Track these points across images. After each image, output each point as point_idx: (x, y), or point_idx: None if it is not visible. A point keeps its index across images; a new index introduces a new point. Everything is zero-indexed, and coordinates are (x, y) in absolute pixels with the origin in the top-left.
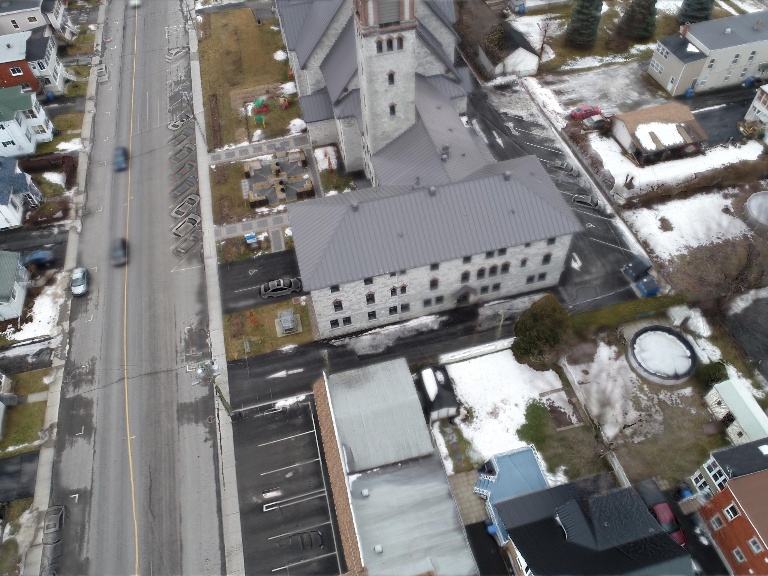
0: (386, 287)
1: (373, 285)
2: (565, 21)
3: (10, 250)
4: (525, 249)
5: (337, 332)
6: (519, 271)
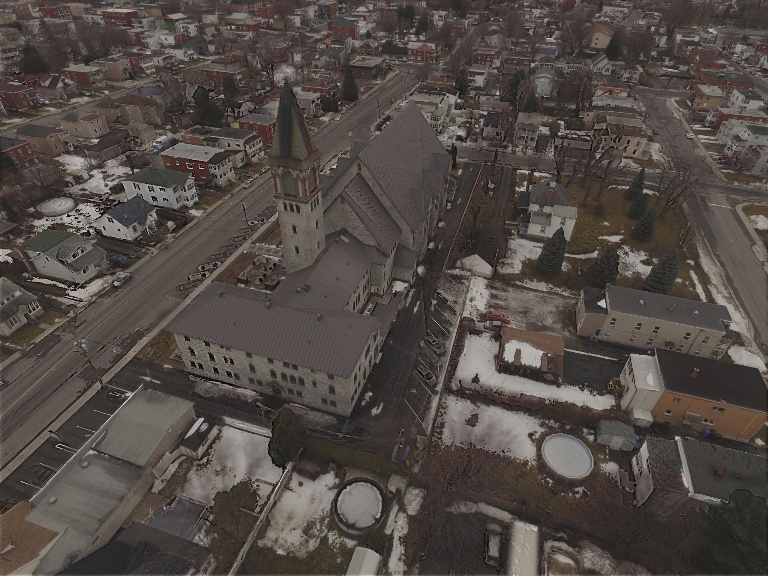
0: (220, 354)
1: (211, 348)
2: None
3: (116, 251)
4: (312, 373)
5: (196, 371)
6: (313, 389)
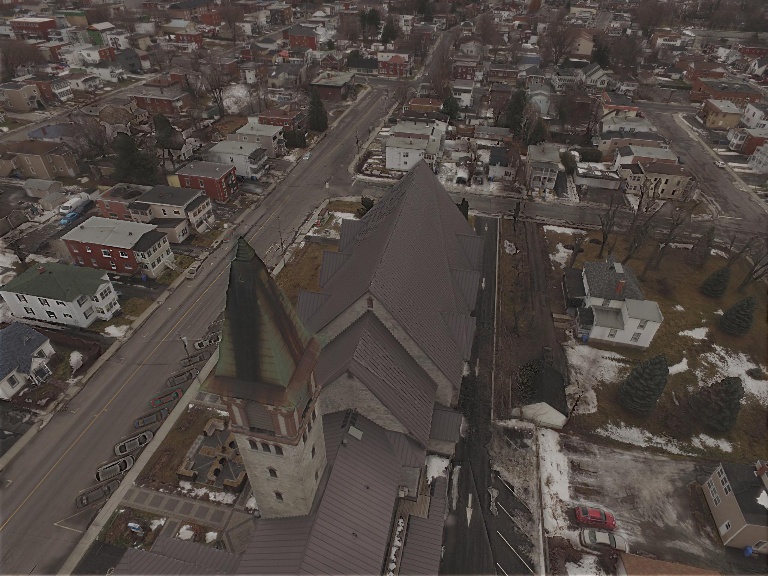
0: None
1: None
2: (629, 368)
3: None
4: None
5: None
6: None
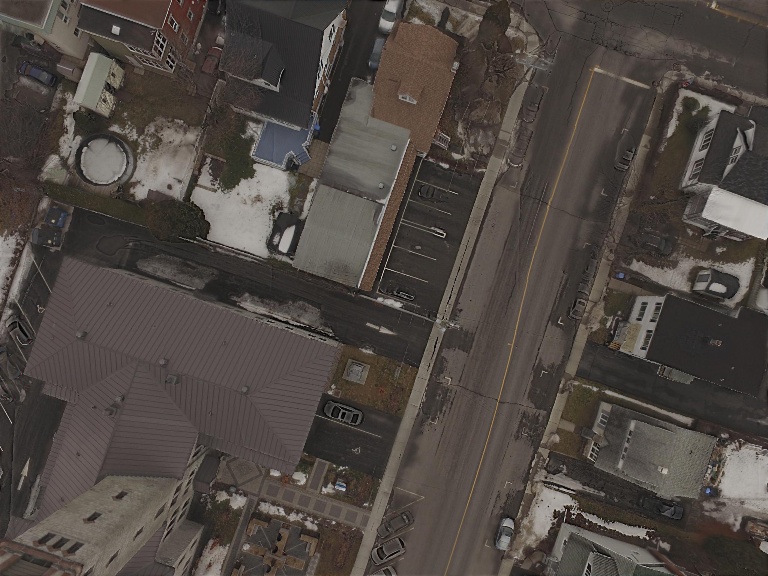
0: None
1: None
2: None
3: None
4: None
5: None
6: None
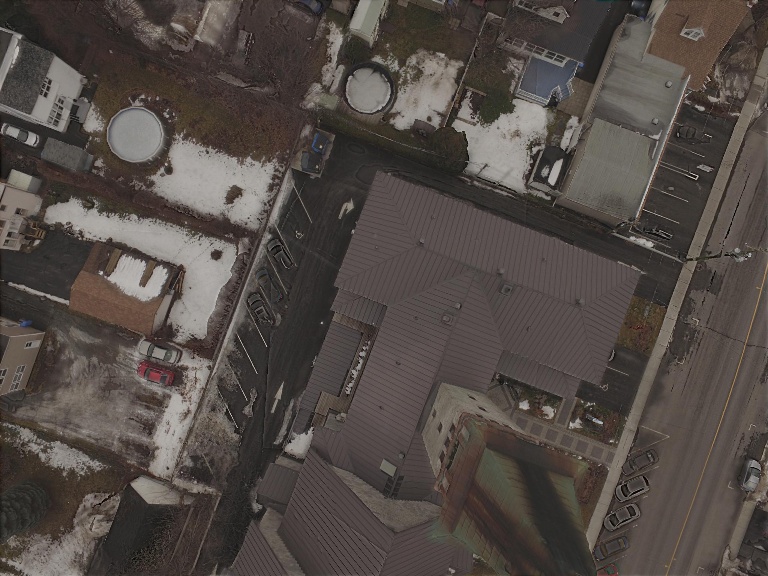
0: None
1: None
2: (4, 556)
3: None
4: None
5: None
6: None
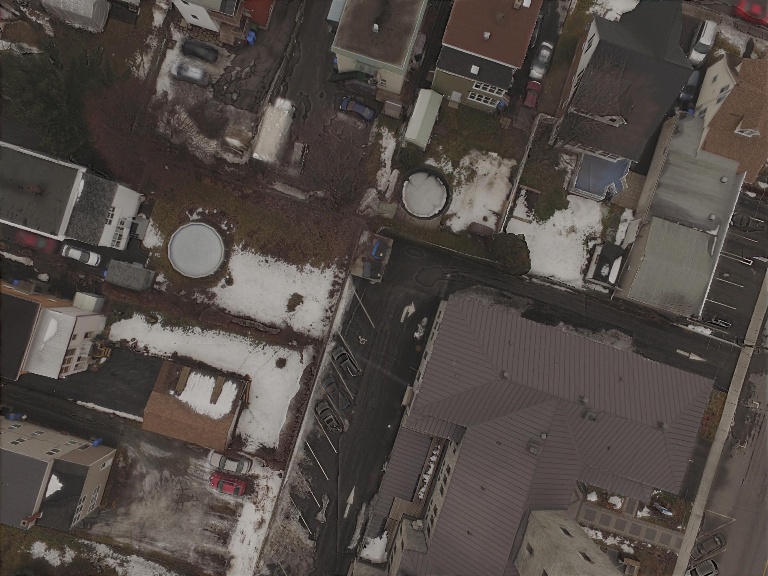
0: None
1: None
2: None
3: None
4: None
5: None
6: None
